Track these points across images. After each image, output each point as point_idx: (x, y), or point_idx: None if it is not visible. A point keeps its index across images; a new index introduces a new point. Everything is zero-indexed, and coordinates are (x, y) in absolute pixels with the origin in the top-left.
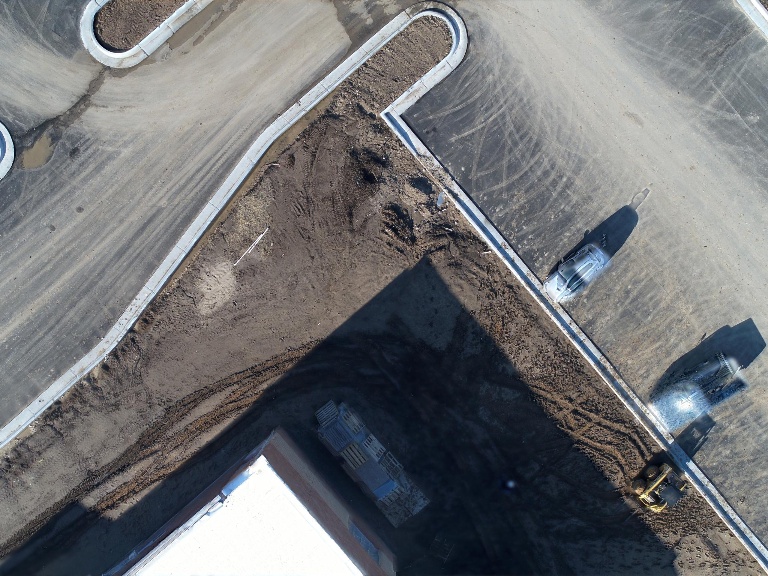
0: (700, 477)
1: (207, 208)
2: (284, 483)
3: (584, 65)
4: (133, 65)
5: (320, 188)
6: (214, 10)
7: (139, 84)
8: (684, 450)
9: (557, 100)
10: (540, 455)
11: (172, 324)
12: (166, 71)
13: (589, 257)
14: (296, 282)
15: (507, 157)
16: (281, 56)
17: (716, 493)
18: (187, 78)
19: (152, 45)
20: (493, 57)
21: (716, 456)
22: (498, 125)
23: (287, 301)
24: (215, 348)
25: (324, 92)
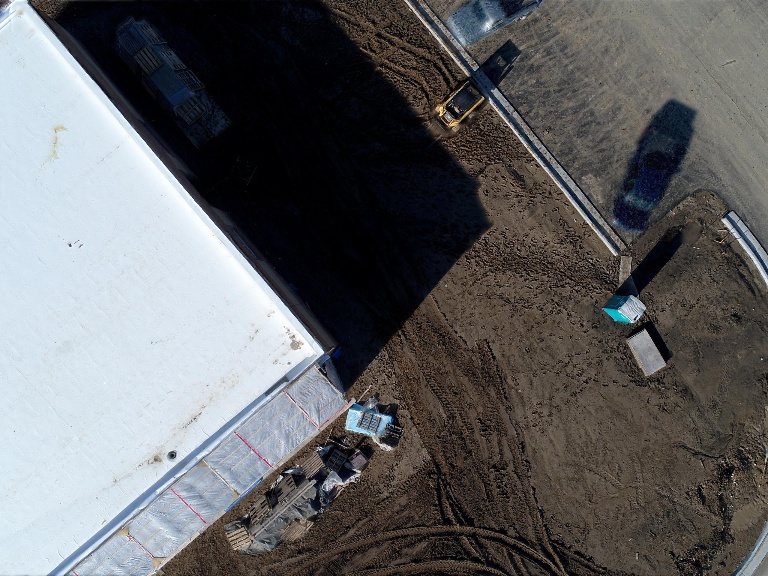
0: (505, 105)
1: None
2: (45, 22)
3: None
4: None
5: None
6: None
7: None
8: (489, 78)
9: None
10: (343, 77)
11: None
12: None
13: None
14: None
15: None
16: None
17: (522, 122)
18: None
19: None
20: None
21: (522, 85)
22: None
23: None
24: None
25: None
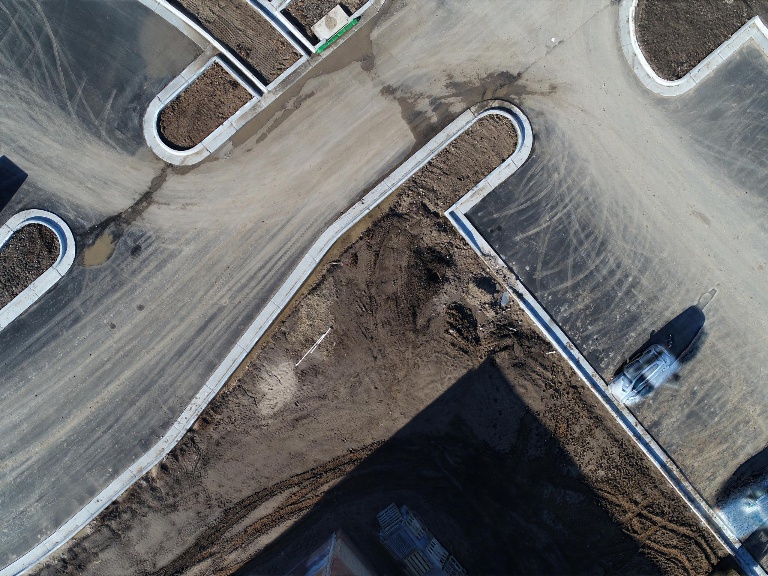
0: None
1: (269, 306)
2: None
3: (650, 164)
4: (196, 162)
5: (383, 287)
6: (277, 107)
7: (201, 181)
8: (751, 555)
9: (623, 199)
10: (605, 560)
11: (233, 424)
12: (229, 168)
13: (655, 358)
14: (358, 383)
15: (572, 256)
16: (344, 154)
17: None
18: (250, 176)
19: (215, 142)
20: (558, 156)
21: None
22: (563, 224)
23: (349, 402)
24: (276, 449)
25: (388, 191)
